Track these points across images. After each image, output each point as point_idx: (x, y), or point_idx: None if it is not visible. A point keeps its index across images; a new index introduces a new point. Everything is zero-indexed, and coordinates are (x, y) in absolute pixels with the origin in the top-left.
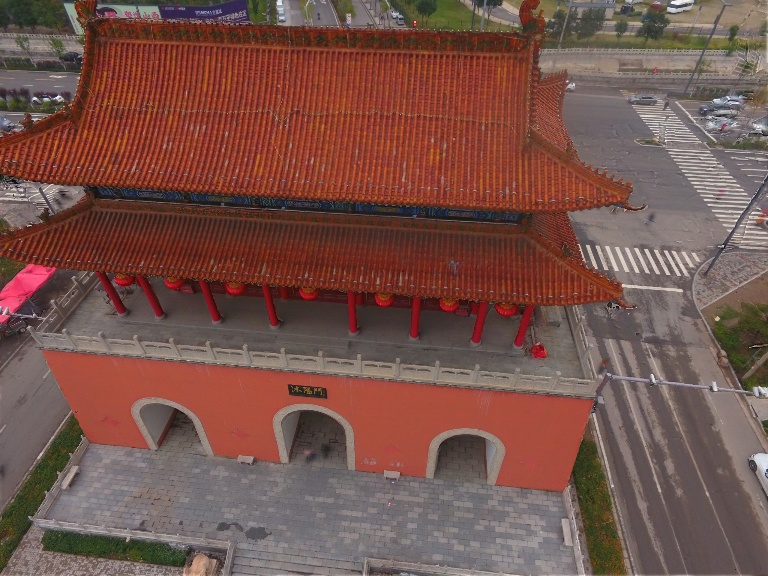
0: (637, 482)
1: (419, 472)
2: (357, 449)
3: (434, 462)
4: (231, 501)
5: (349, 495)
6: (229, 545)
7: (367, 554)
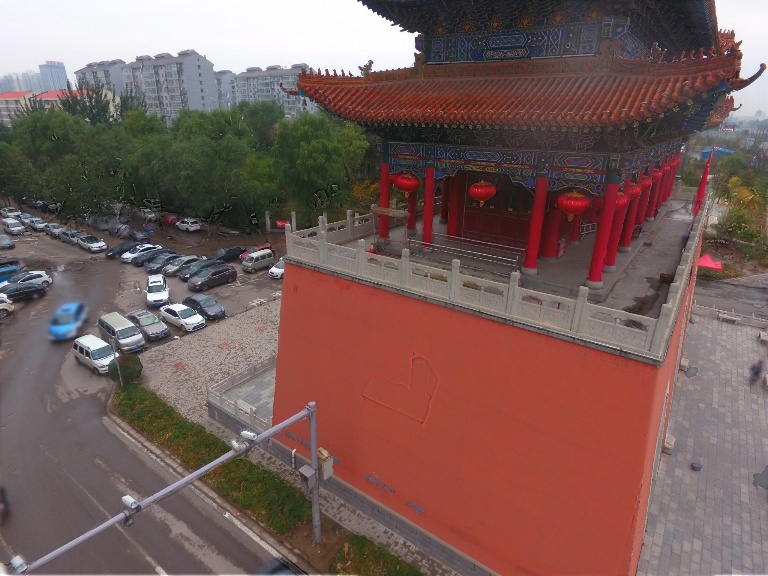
0: (197, 548)
1: None
2: None
3: None
4: None
5: None
6: None
7: None
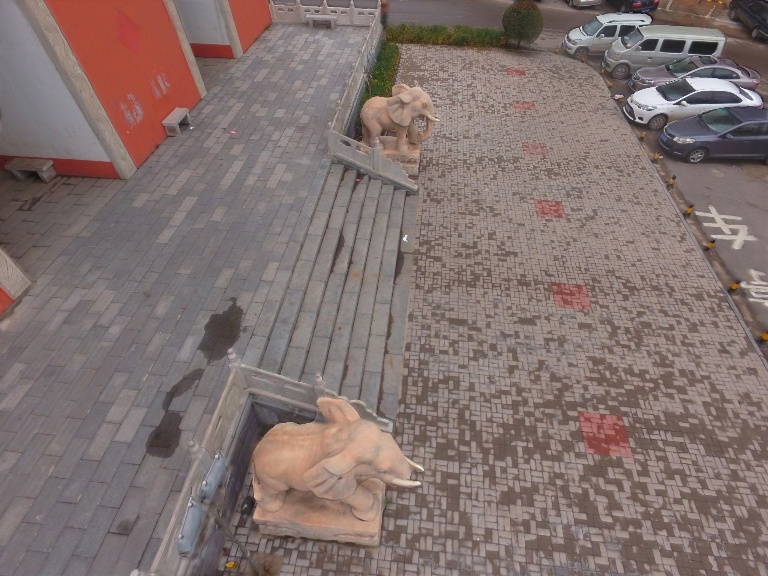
0: None
1: (189, 90)
2: (89, 75)
3: (183, 34)
4: (73, 428)
5: (190, 176)
6: (244, 366)
7: (318, 154)
